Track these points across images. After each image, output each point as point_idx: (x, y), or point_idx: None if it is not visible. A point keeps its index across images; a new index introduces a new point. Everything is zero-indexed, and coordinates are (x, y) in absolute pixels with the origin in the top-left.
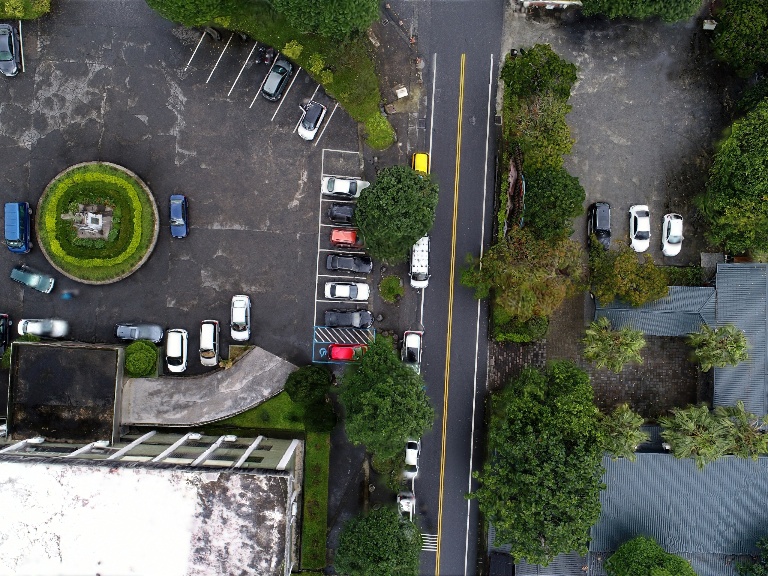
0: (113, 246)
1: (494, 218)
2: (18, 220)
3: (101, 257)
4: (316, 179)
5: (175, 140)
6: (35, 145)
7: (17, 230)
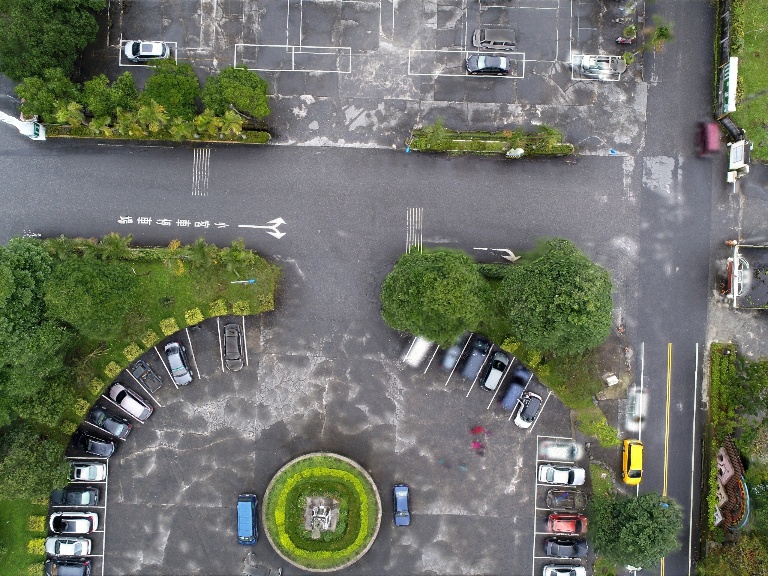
0: (341, 539)
1: (702, 499)
2: (251, 518)
3: (330, 550)
4: (531, 465)
5: (395, 429)
6: (259, 436)
7: (250, 528)
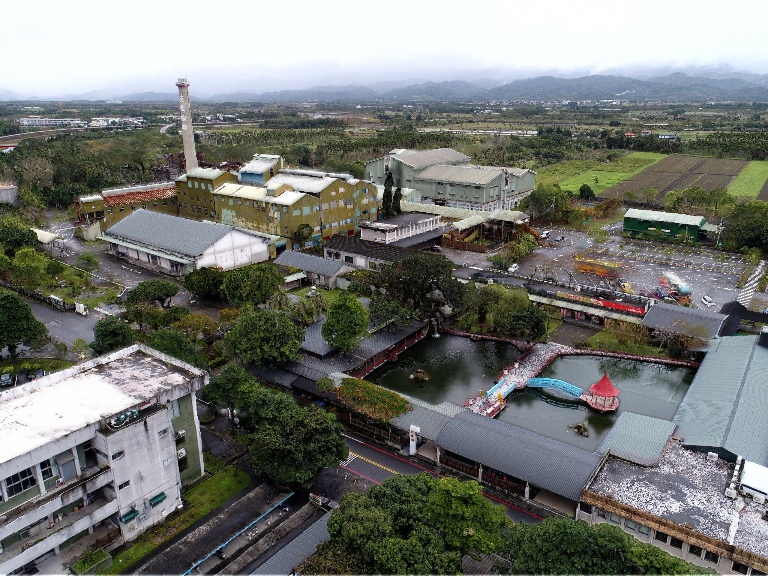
0: None
1: None
2: None
3: None
4: None
5: None
6: None
7: None
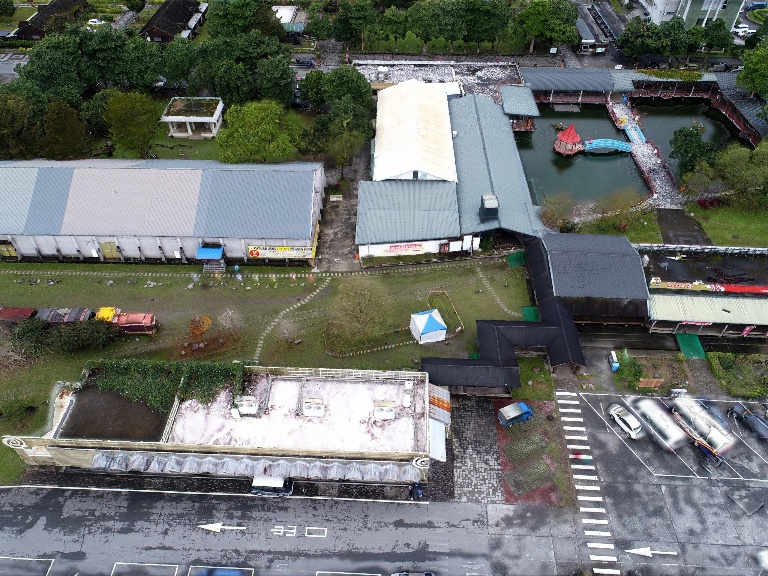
0: None
1: None
2: (761, 4)
3: (761, 16)
4: None
5: None
6: None
7: (758, 3)
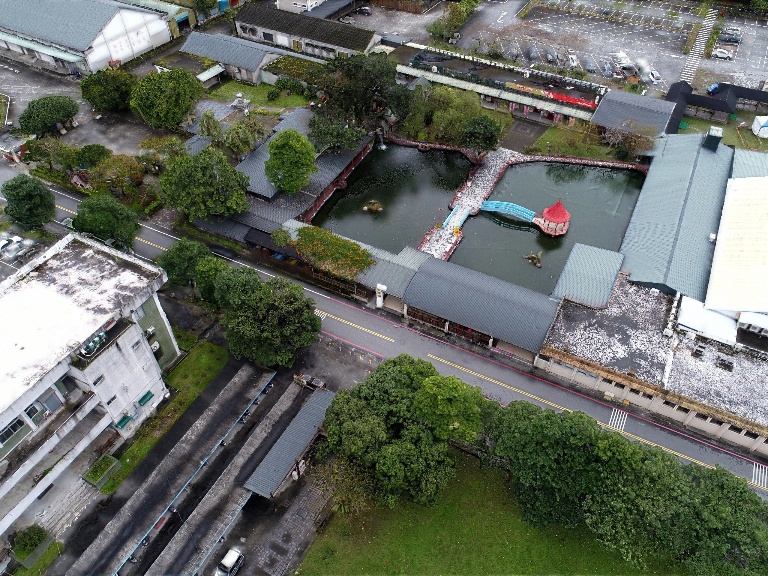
0: None
1: None
2: None
3: None
4: None
5: None
6: None
7: None
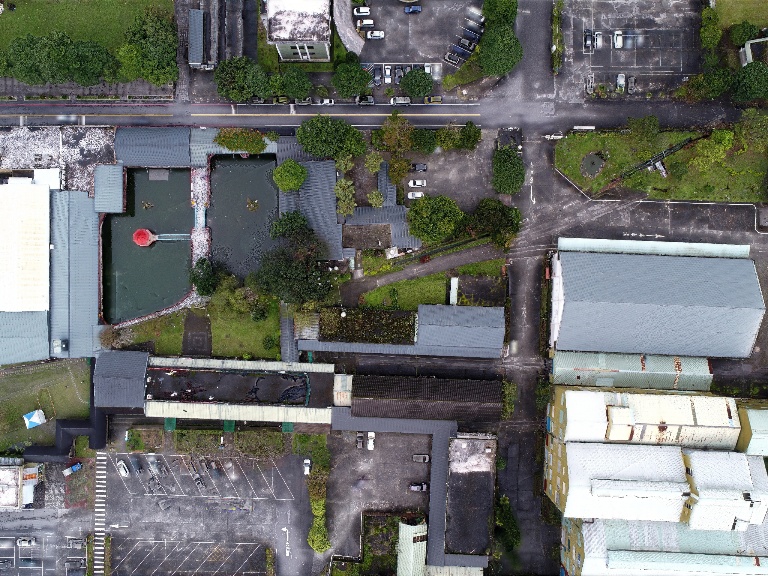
0: None
1: None
2: None
3: None
4: (430, 61)
5: (442, 7)
6: None
7: None
